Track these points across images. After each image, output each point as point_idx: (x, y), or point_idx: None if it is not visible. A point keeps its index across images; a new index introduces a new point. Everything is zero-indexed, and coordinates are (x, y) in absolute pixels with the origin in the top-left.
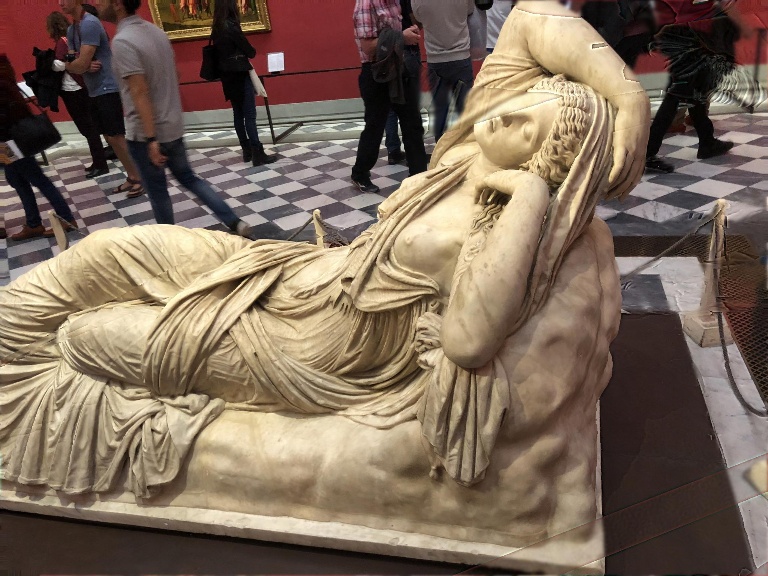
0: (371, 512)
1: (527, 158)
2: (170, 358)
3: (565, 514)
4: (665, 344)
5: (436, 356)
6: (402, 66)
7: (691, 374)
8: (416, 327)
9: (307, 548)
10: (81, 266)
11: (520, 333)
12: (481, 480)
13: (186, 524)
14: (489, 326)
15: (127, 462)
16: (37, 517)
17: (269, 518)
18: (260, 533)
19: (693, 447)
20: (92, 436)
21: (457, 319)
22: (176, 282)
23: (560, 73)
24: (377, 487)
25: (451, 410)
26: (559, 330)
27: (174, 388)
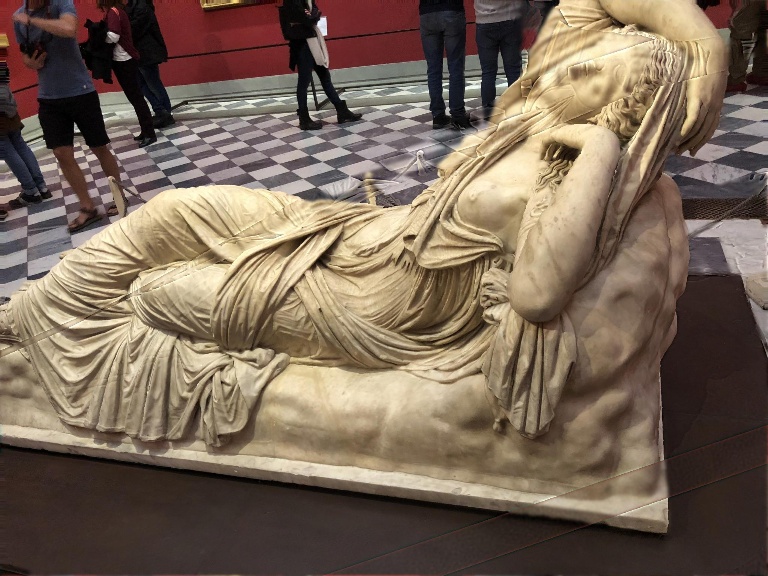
0: (434, 463)
1: (596, 112)
2: (238, 313)
3: (628, 468)
4: (727, 305)
5: (502, 311)
6: (512, 4)
7: (754, 335)
8: (481, 283)
9: (371, 496)
10: (151, 225)
11: (588, 288)
12: (545, 433)
13: (255, 471)
14: (559, 280)
15: (198, 412)
16: (114, 463)
17: (334, 467)
18: (326, 481)
19: (757, 407)
20: (165, 387)
21: (526, 273)
22: (291, 219)
23: (632, 23)
24: (440, 439)
25: (517, 363)
26: (627, 285)
27: (242, 342)
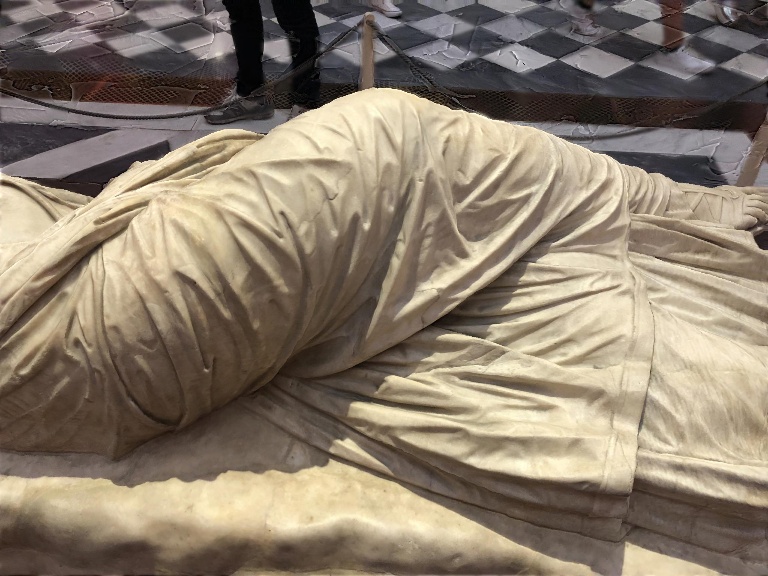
0: None
1: None
2: None
3: None
4: None
5: None
6: None
7: None
8: None
9: None
10: None
11: None
12: None
13: None
14: None
15: None
16: None
17: None
18: None
19: None
20: None
21: None
22: None
23: None
24: None
25: None
26: None
27: None
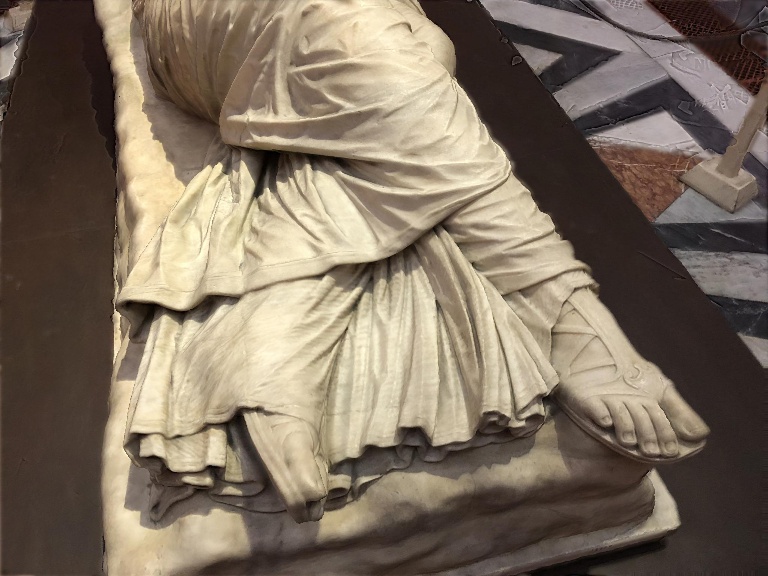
0: None
1: None
2: None
3: None
4: None
5: None
6: None
7: None
8: None
9: None
10: None
11: None
12: None
13: None
14: None
15: None
16: None
17: None
18: None
19: None
20: None
21: None
22: None
23: None
24: None
25: None
26: None
27: None
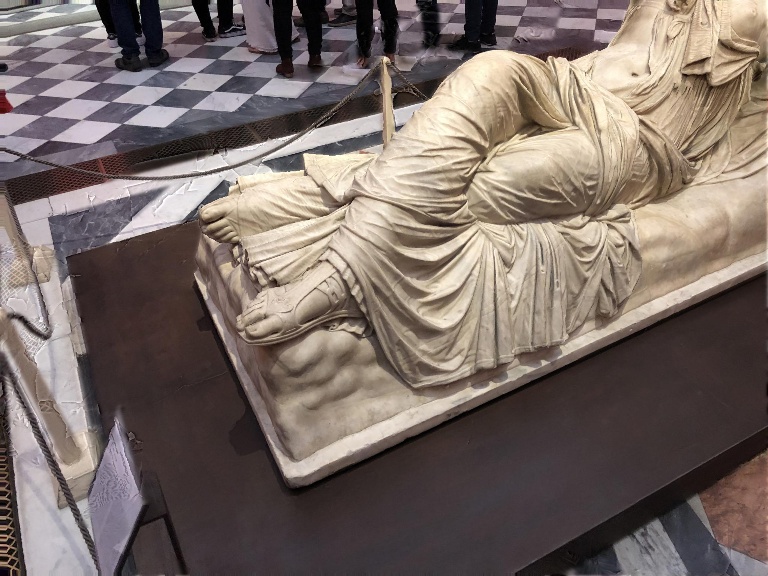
0: (758, 241)
1: None
2: None
3: None
4: None
5: None
6: None
7: None
8: None
9: None
10: (494, 101)
11: None
12: None
13: (648, 320)
14: None
15: None
16: (497, 401)
17: (696, 283)
18: (701, 295)
19: None
20: None
21: None
22: None
23: None
24: None
25: None
26: None
27: (609, 202)
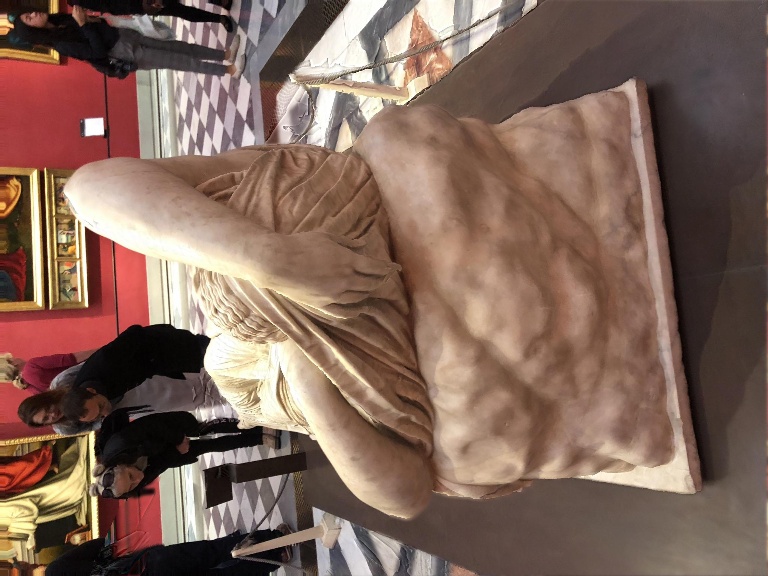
0: None
1: None
2: None
3: None
4: None
5: None
6: None
7: None
8: None
9: None
10: None
11: None
12: None
13: None
14: (395, 511)
15: None
16: None
17: None
18: None
19: None
20: None
21: None
22: None
23: None
24: None
25: None
26: (461, 440)
27: None
